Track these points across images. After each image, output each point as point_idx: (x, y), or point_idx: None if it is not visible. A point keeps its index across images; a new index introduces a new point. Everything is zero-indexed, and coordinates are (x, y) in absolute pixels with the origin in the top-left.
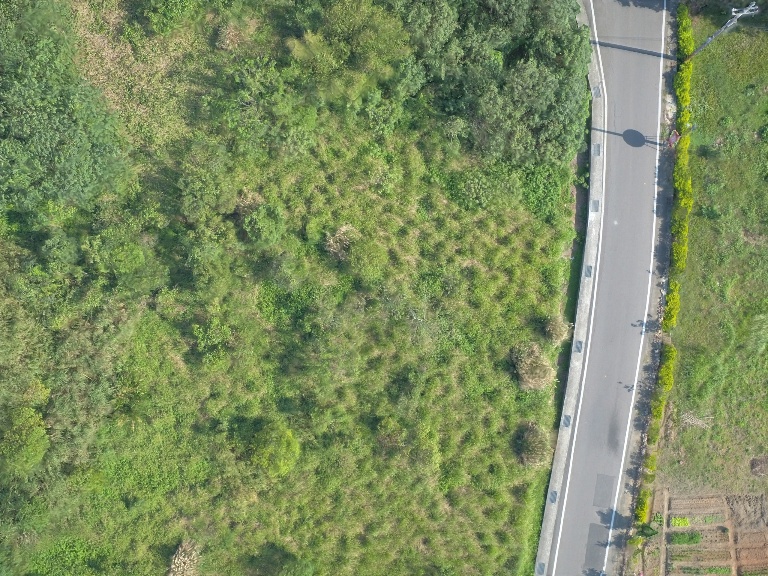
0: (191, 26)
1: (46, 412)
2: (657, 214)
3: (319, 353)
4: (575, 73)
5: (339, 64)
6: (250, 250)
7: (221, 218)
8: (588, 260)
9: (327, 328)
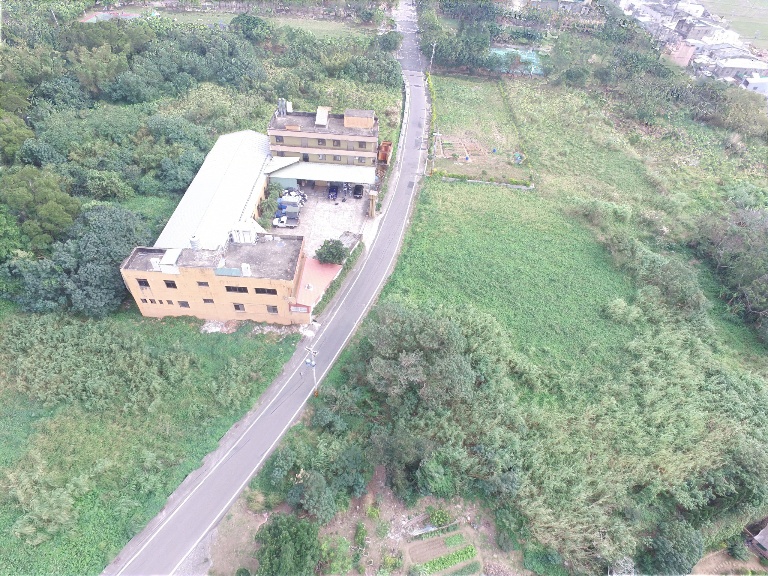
0: None
1: None
2: None
3: None
4: None
5: None
6: None
7: None
8: None
9: None
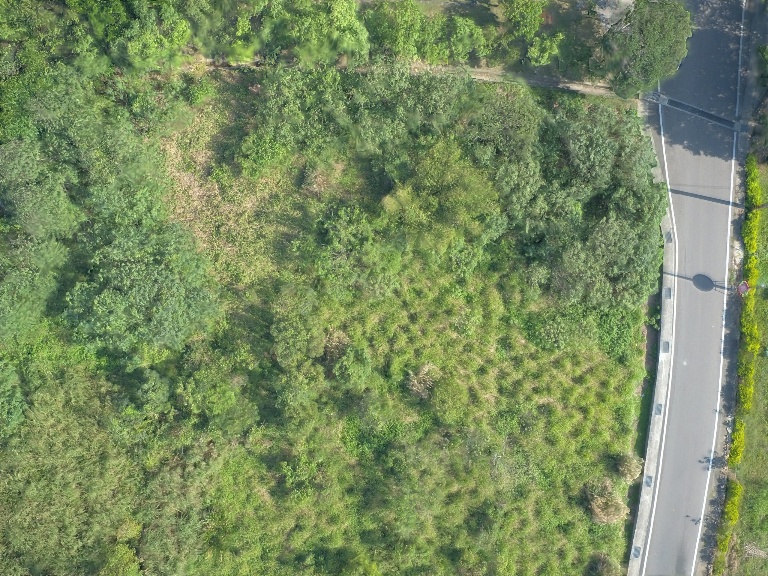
0: (277, 167)
1: (139, 546)
2: (724, 356)
3: (401, 486)
4: (653, 228)
5: (426, 215)
6: (334, 386)
7: (311, 361)
8: (658, 399)
9: (409, 462)
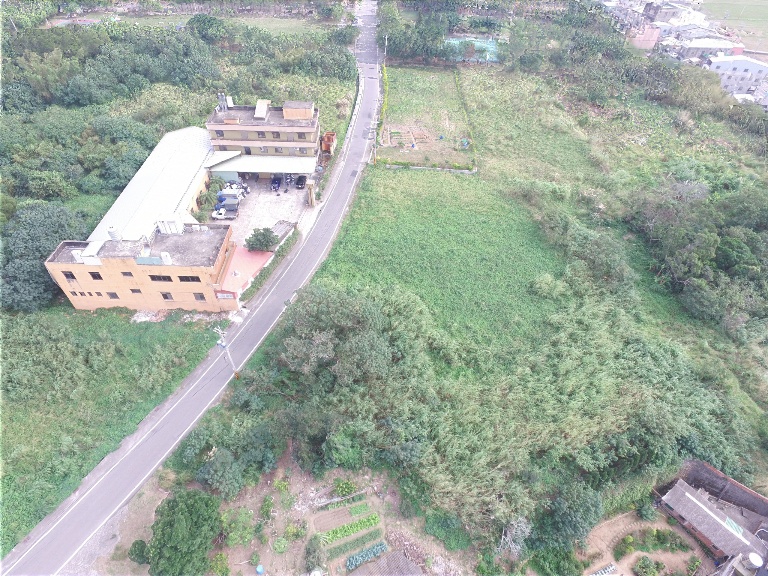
0: None
1: None
2: (379, 87)
3: None
4: (351, 61)
5: None
6: None
7: None
8: None
9: None
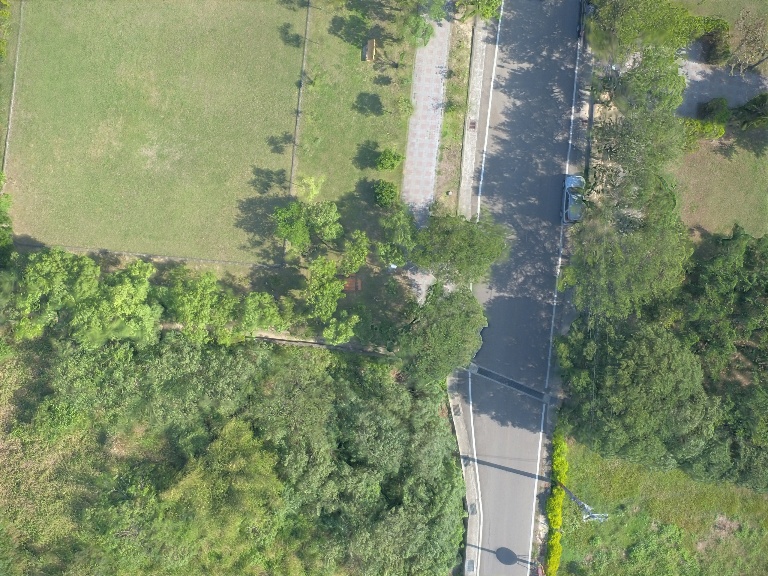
0: None
1: None
2: None
3: None
4: (446, 515)
5: (219, 492)
6: None
7: None
8: None
9: None
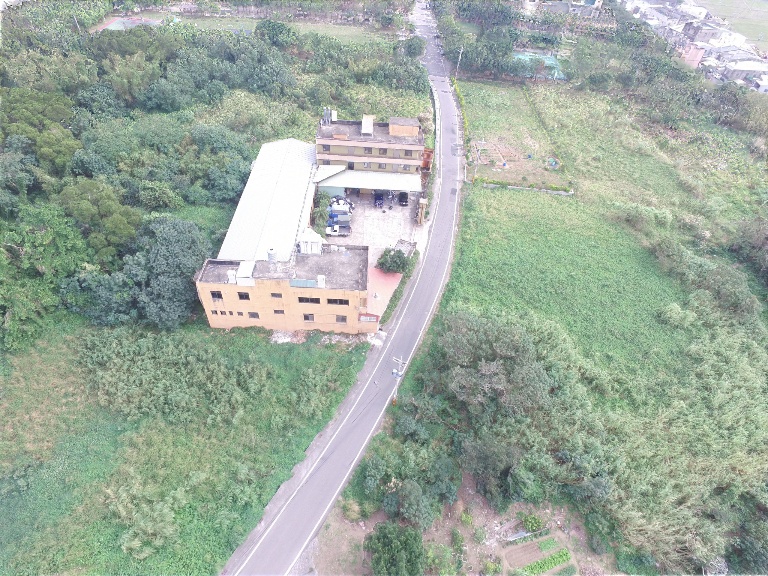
0: None
1: None
2: (454, 101)
3: None
4: None
5: None
6: None
7: None
8: None
9: None
